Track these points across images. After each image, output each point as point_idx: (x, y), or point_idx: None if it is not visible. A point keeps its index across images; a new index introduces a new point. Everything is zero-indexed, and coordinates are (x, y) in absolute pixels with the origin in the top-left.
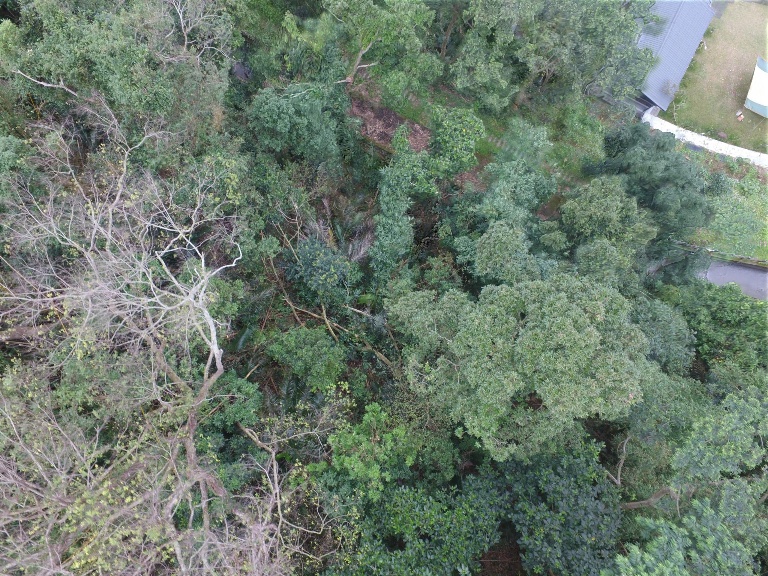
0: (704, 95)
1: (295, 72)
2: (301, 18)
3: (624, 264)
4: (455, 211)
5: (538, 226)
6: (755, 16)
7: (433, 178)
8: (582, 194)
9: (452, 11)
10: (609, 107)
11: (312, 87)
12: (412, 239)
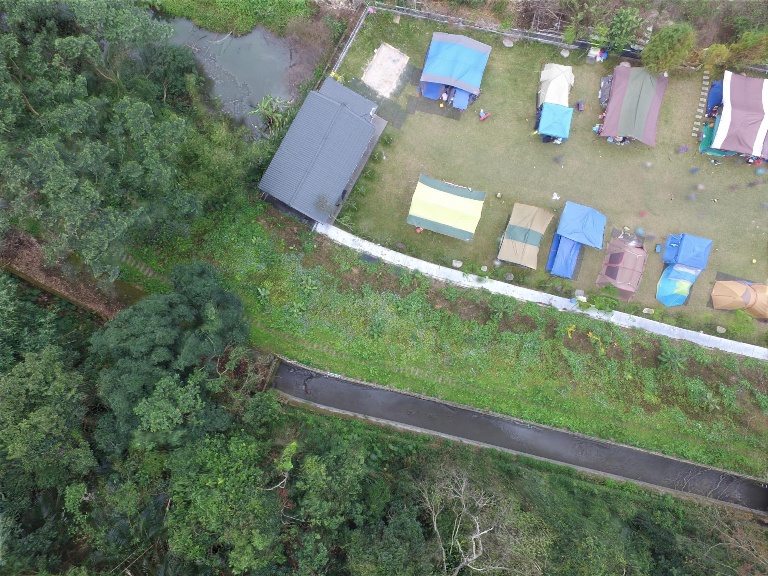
0: (383, 205)
1: None
2: None
3: (25, 451)
4: None
5: None
6: (436, 128)
7: None
8: None
9: None
10: (282, 214)
11: None
12: None
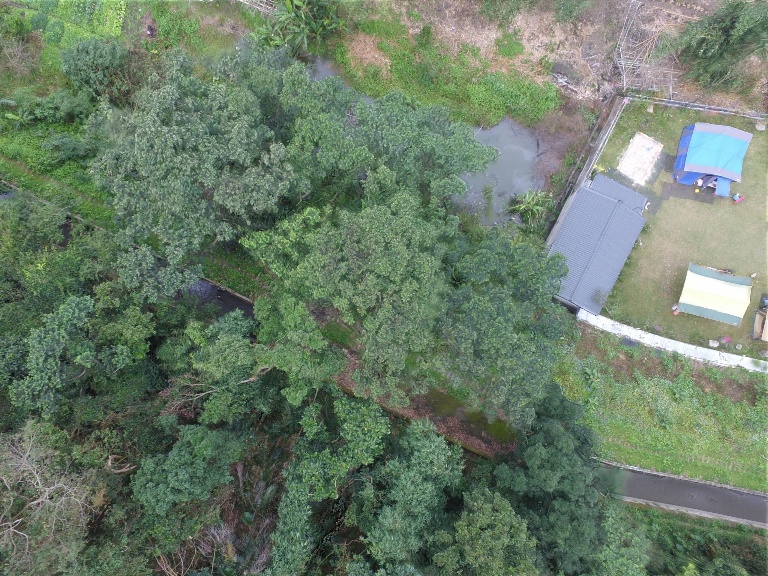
0: (640, 290)
1: (200, 371)
2: (229, 249)
3: None
4: (361, 497)
5: (433, 539)
6: (690, 212)
7: (335, 476)
8: (475, 513)
9: None
10: None
11: (215, 389)
12: (307, 559)
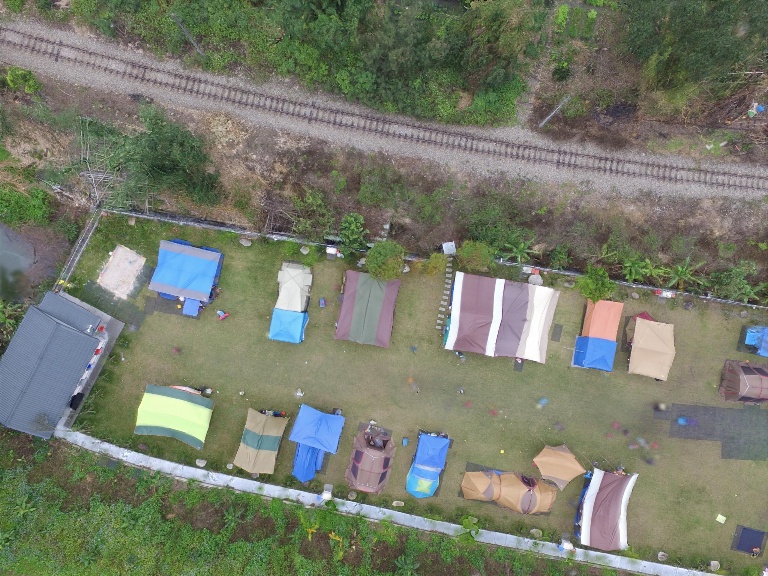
0: (123, 406)
1: None
2: None
3: None
4: None
5: None
6: (176, 328)
7: None
8: None
9: None
10: None
11: None
12: None
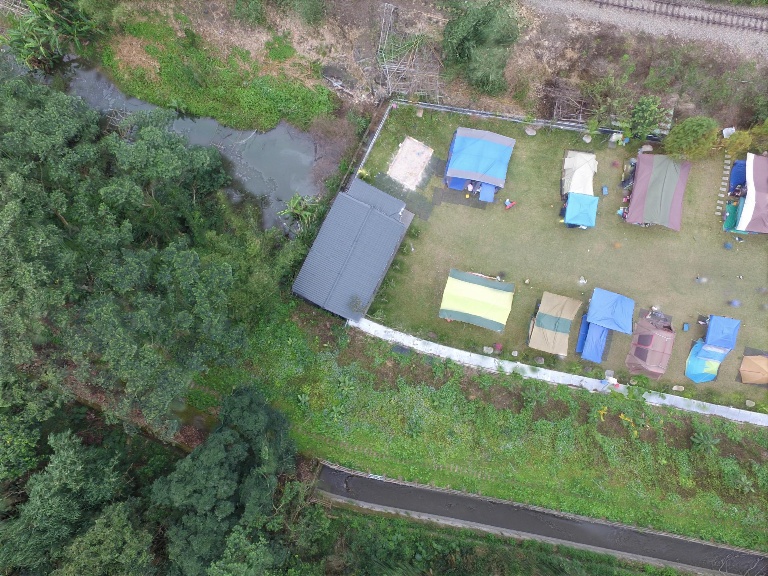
0: (413, 296)
1: None
2: None
3: None
4: (17, 511)
5: (58, 555)
6: (462, 218)
7: None
8: None
9: (143, 222)
10: (314, 310)
11: None
12: None
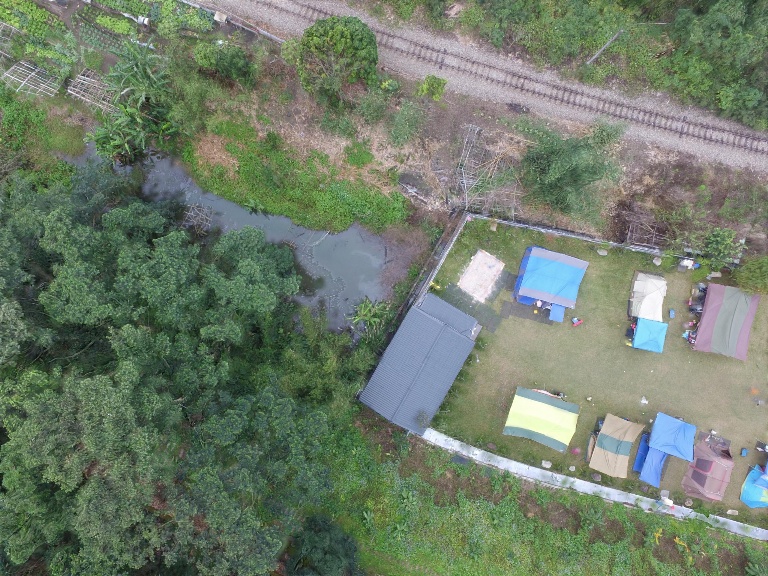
0: (475, 406)
1: None
2: None
3: None
4: None
5: None
6: (529, 332)
7: None
8: None
9: None
10: (377, 415)
11: None
12: None
